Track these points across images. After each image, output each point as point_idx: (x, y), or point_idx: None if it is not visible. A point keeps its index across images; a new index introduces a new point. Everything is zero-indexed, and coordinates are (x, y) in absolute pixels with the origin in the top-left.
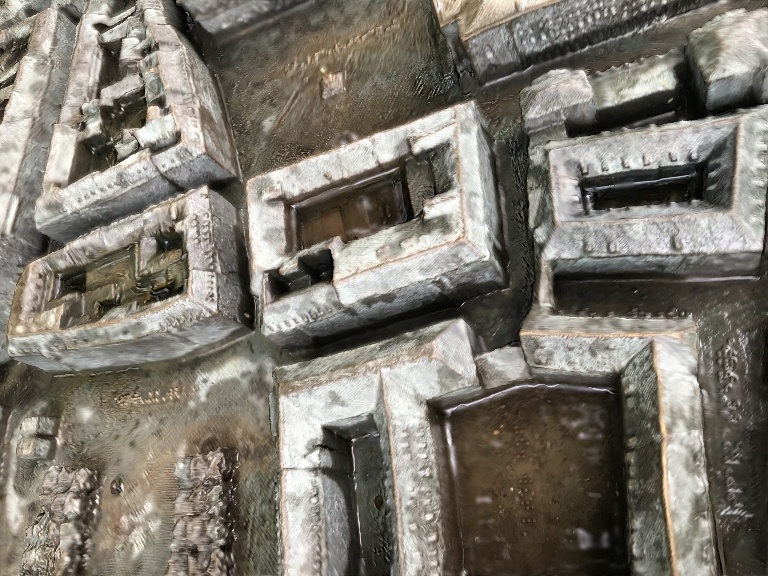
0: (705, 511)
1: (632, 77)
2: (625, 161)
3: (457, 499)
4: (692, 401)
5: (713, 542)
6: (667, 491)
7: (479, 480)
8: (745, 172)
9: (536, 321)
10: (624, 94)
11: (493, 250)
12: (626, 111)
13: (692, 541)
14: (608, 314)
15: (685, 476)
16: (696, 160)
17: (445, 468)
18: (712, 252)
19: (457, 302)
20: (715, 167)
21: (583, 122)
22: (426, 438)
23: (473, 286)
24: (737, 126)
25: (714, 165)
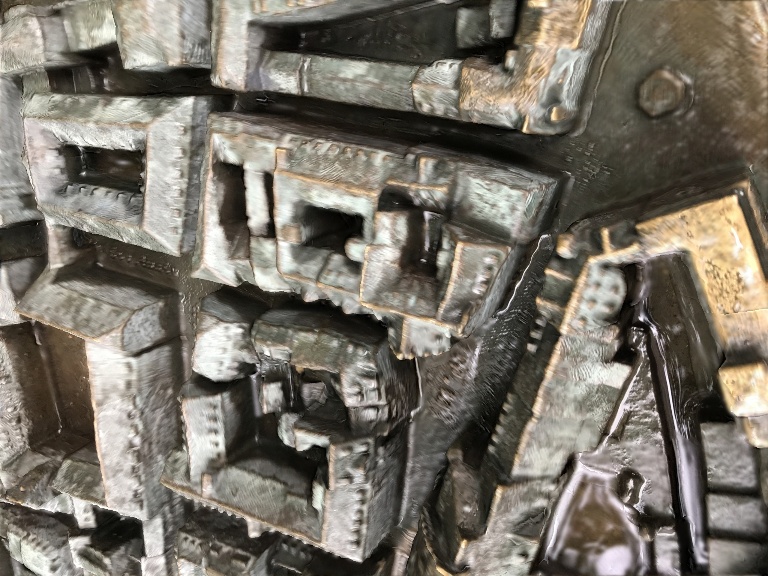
0: (134, 447)
1: (101, 12)
2: (85, 140)
3: (49, 383)
4: (128, 376)
5: (166, 448)
6: (98, 442)
7: (67, 367)
8: (157, 185)
9: (34, 293)
10: (94, 37)
11: (21, 200)
12: (113, 46)
13: (123, 465)
14: (129, 257)
15: (118, 428)
16: (139, 149)
17: (32, 366)
18: (150, 249)
19: (31, 223)
20: (144, 168)
21: (68, 64)
22: (2, 355)
23: (27, 221)
24: (146, 135)
25: (144, 165)
